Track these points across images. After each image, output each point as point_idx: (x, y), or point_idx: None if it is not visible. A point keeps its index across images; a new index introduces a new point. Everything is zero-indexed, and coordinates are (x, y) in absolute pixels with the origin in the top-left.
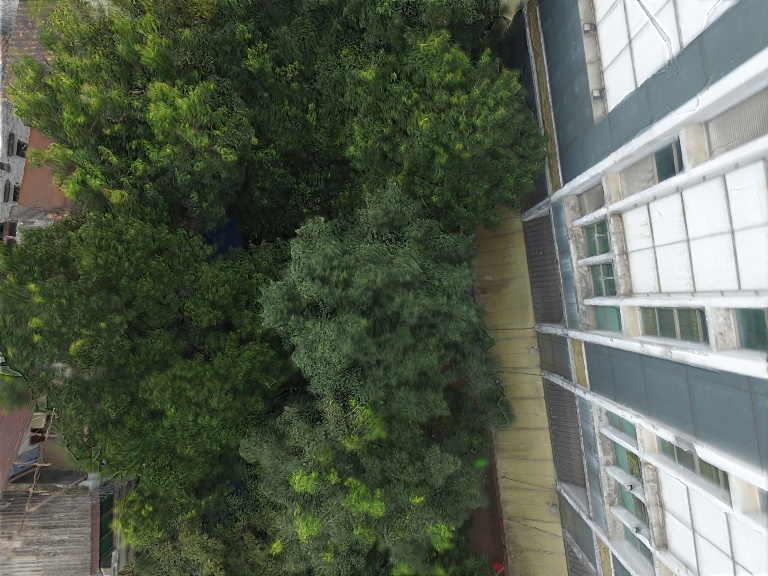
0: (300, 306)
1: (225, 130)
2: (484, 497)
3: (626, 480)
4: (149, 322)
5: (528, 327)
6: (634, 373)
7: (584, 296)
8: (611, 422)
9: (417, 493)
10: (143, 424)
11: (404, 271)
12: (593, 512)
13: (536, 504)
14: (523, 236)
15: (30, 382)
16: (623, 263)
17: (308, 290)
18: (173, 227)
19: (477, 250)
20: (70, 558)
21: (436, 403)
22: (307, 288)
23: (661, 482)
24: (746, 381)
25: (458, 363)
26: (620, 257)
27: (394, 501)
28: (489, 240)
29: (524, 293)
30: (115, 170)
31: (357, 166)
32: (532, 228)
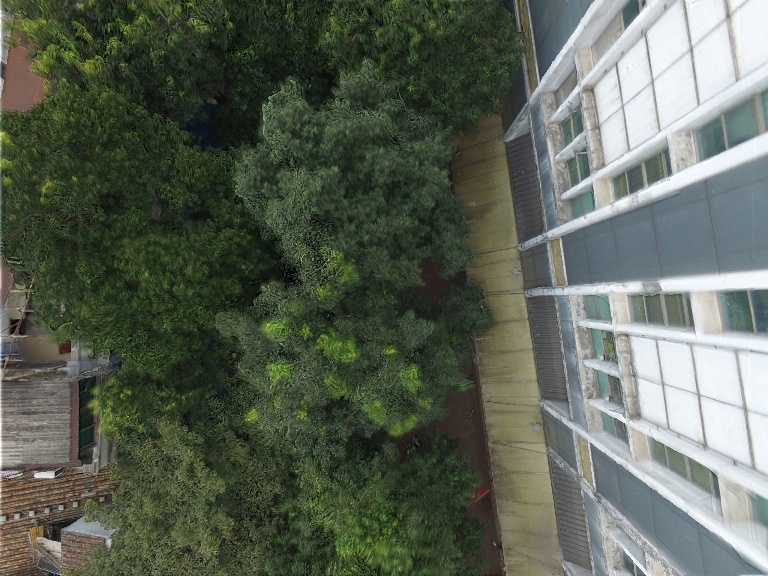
0: (274, 178)
1: (198, 3)
2: (471, 432)
3: (602, 365)
4: (126, 203)
5: (511, 248)
6: (606, 243)
7: (561, 192)
8: (589, 315)
9: (389, 348)
10: (118, 294)
11: (373, 124)
12: (573, 413)
13: (521, 426)
14: (506, 159)
15: (1, 231)
16: (595, 138)
17: (278, 143)
18: (150, 115)
19: (461, 177)
20: (49, 444)
21: (410, 274)
22: (277, 142)
23: (634, 351)
24: (704, 188)
25: (433, 243)
26: (592, 132)
27: (366, 358)
28: (473, 166)
29: (507, 216)
30: (90, 51)
31: (333, 54)
32: (514, 148)
